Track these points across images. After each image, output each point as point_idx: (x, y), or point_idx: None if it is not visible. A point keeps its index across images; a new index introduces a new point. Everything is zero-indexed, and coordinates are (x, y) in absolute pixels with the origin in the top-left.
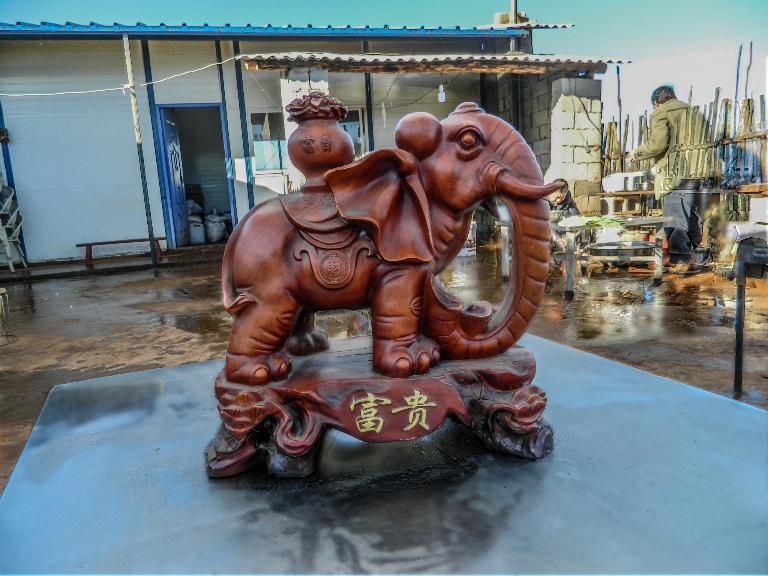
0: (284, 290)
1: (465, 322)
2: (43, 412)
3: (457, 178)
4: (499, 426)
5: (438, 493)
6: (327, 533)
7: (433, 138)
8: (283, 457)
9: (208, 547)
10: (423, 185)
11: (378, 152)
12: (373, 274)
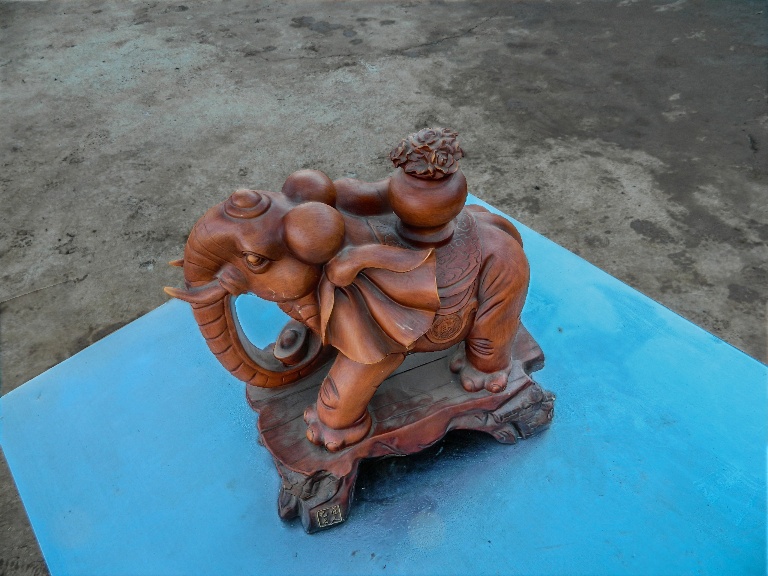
0: None
1: None
2: None
3: None
4: None
5: None
6: None
7: None
8: None
9: None
10: None
11: None
12: None
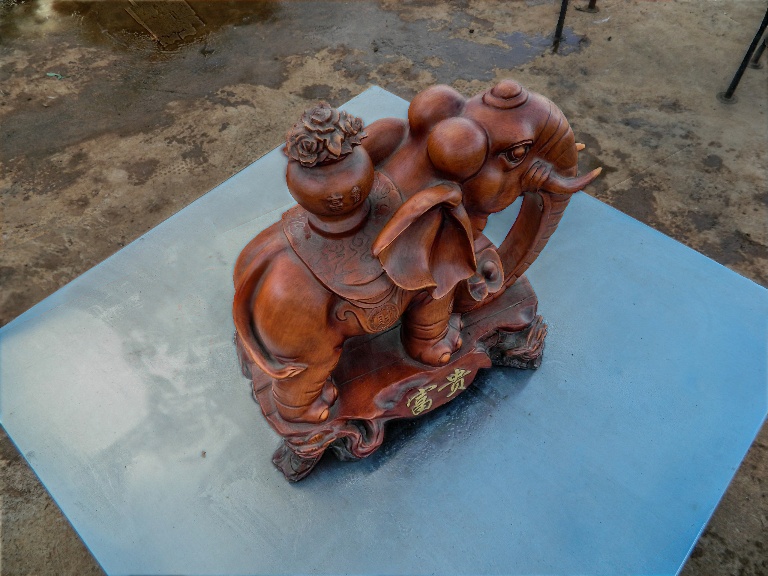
0: (334, 350)
1: None
2: (2, 421)
3: (501, 192)
4: None
5: (487, 441)
6: (434, 521)
7: None
8: None
9: (355, 569)
10: (463, 204)
11: (430, 207)
12: (414, 299)
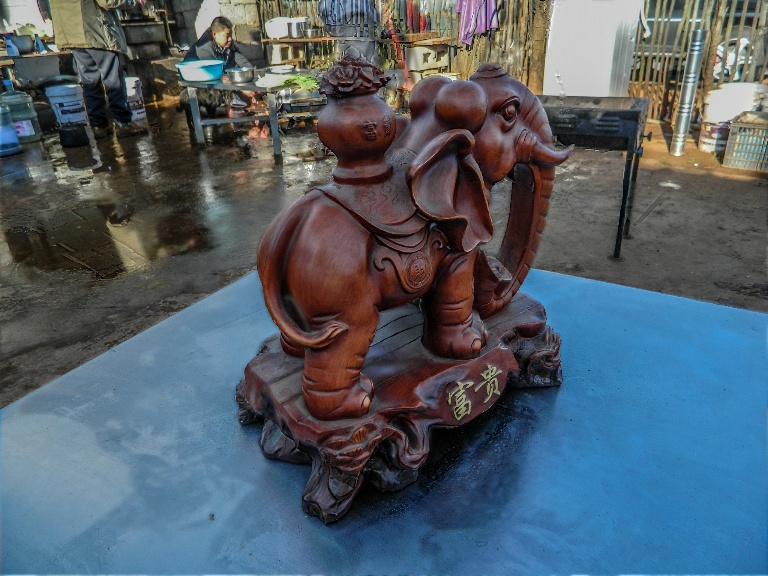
0: (373, 307)
1: (500, 286)
2: None
3: (502, 151)
4: (532, 368)
5: (538, 448)
6: (511, 528)
7: (485, 112)
8: (397, 472)
9: None
10: None
11: (452, 137)
12: (441, 265)
